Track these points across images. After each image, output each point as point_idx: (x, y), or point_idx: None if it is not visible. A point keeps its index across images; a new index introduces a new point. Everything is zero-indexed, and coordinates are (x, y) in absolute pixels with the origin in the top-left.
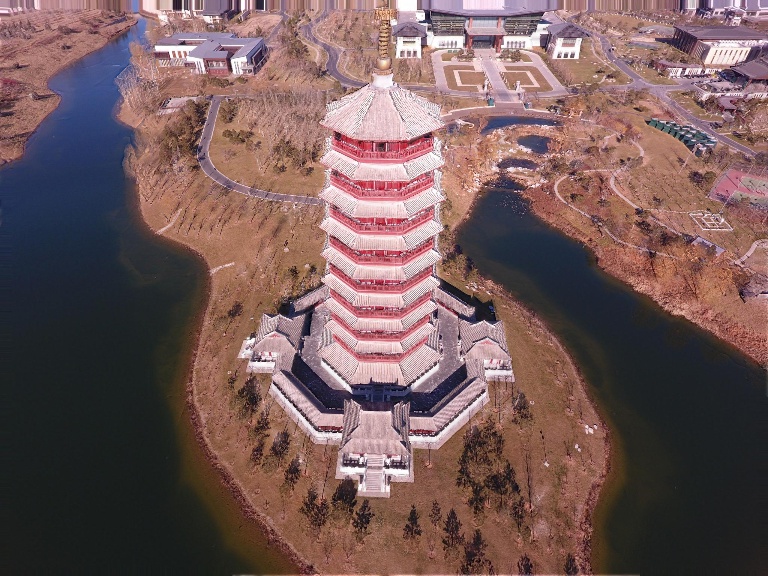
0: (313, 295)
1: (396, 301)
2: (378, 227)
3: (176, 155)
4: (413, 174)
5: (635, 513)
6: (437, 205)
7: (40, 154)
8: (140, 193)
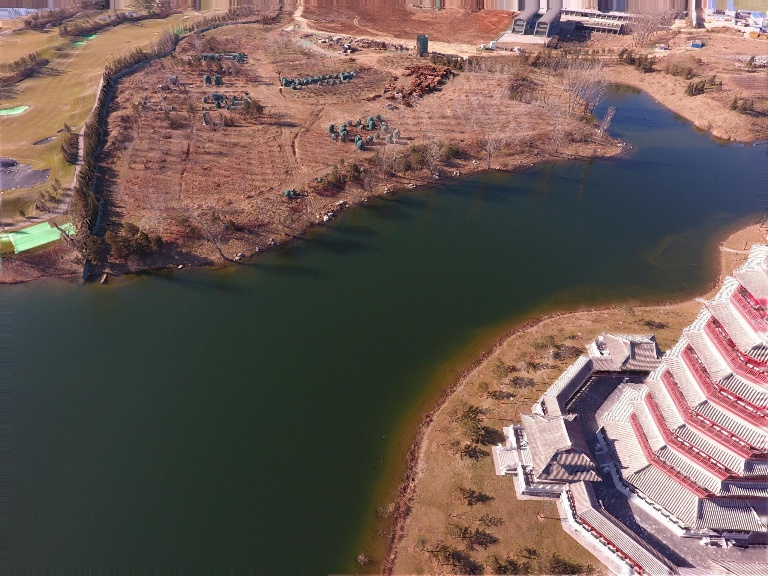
0: None
1: (695, 397)
2: (749, 309)
3: None
4: None
5: None
6: None
7: (766, 152)
8: None
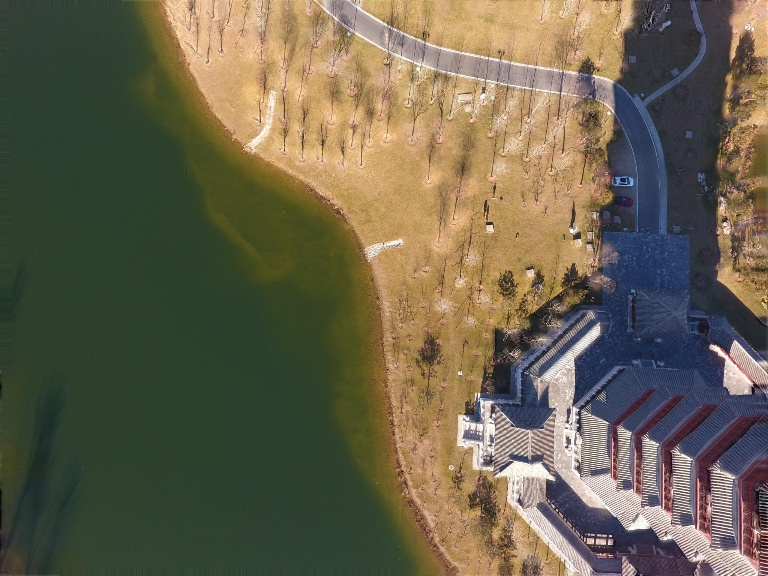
0: (559, 362)
1: None
2: None
3: None
4: None
5: None
6: None
7: None
8: (171, 21)
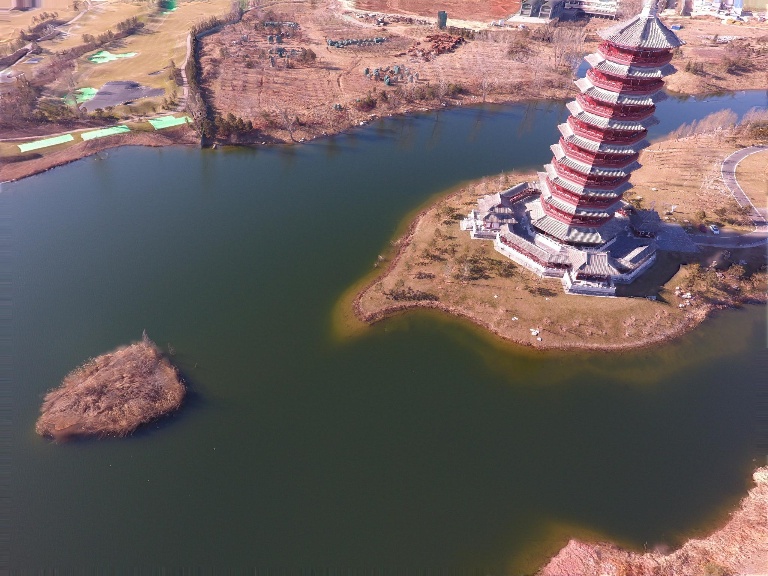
0: None
1: None
2: None
3: (747, 133)
4: (601, 67)
5: (472, 344)
6: (637, 127)
7: None
8: None
